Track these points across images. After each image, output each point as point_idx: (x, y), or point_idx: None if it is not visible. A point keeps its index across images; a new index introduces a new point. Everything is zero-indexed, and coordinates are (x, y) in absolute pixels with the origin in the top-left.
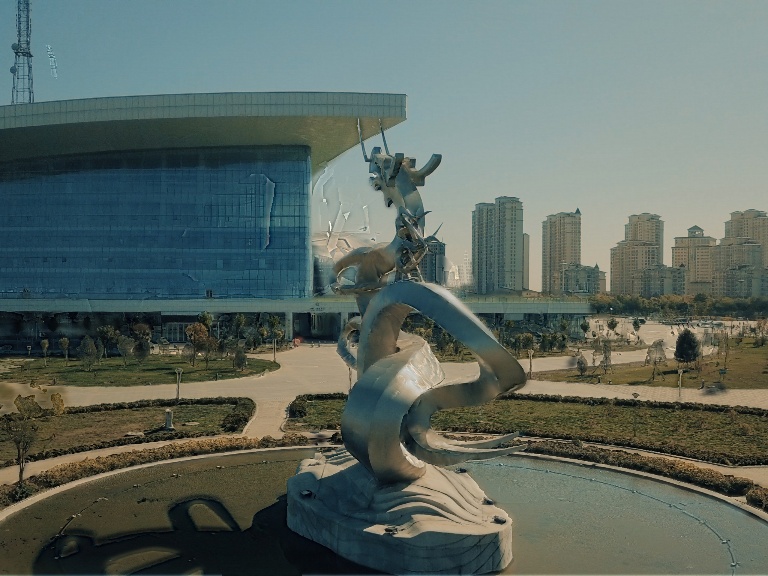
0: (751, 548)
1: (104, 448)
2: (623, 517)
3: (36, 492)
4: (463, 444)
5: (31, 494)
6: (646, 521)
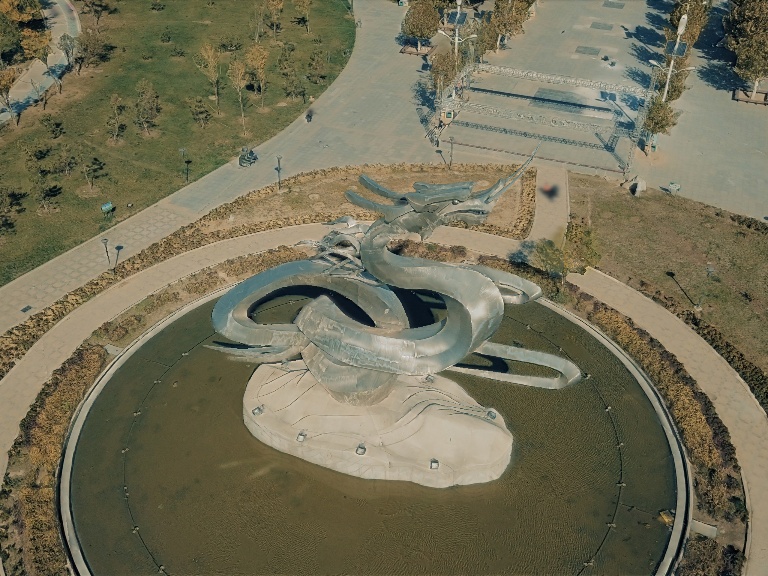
0: (142, 575)
1: (730, 364)
2: (265, 568)
3: (574, 309)
4: (264, 353)
5: (555, 301)
6: (243, 573)
